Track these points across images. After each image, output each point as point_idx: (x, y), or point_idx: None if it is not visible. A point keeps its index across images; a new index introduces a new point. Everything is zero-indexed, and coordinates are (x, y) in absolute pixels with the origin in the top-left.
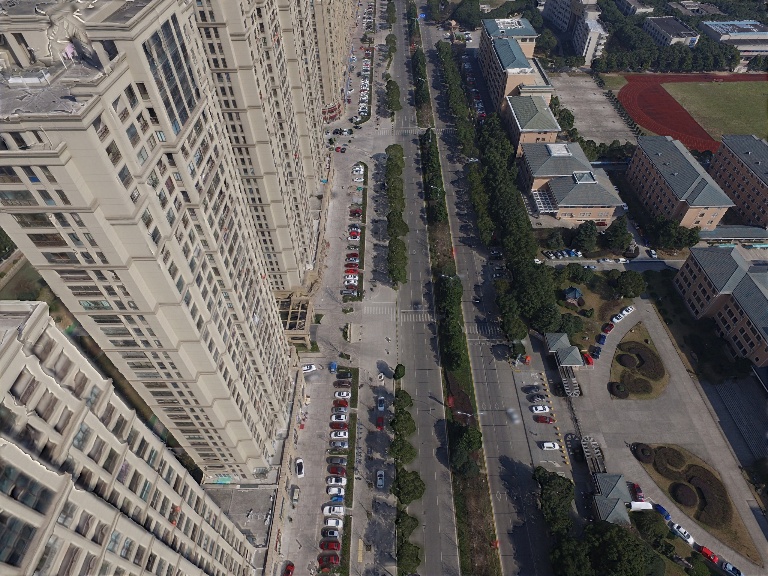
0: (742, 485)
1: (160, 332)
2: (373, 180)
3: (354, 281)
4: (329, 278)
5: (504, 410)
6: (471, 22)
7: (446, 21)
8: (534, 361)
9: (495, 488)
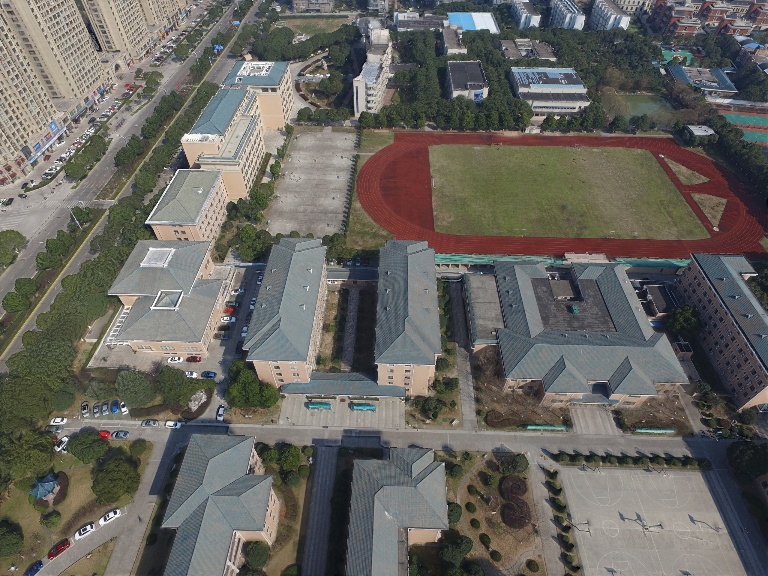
0: None
1: None
2: None
3: None
4: None
5: None
6: (265, 58)
7: (245, 54)
8: None
9: None
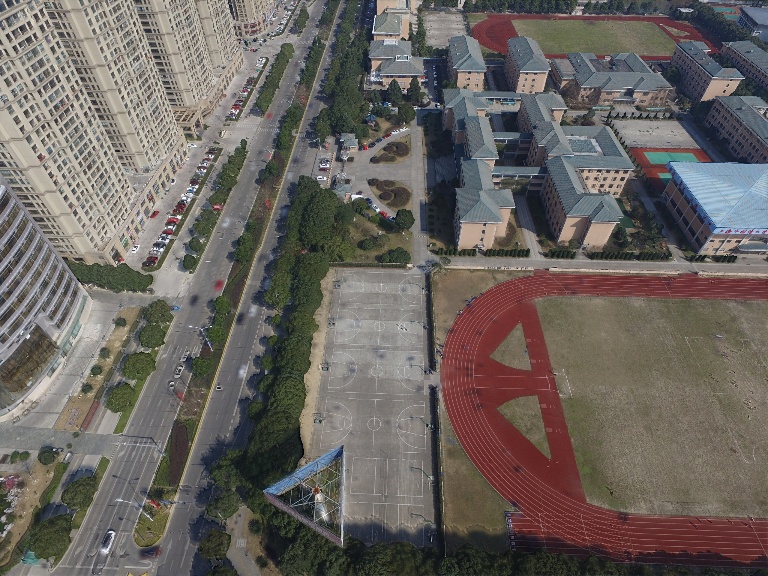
0: (422, 194)
1: (74, 26)
2: (270, 67)
3: (235, 111)
4: (220, 111)
5: (303, 166)
6: None
7: None
8: (332, 148)
9: (282, 193)
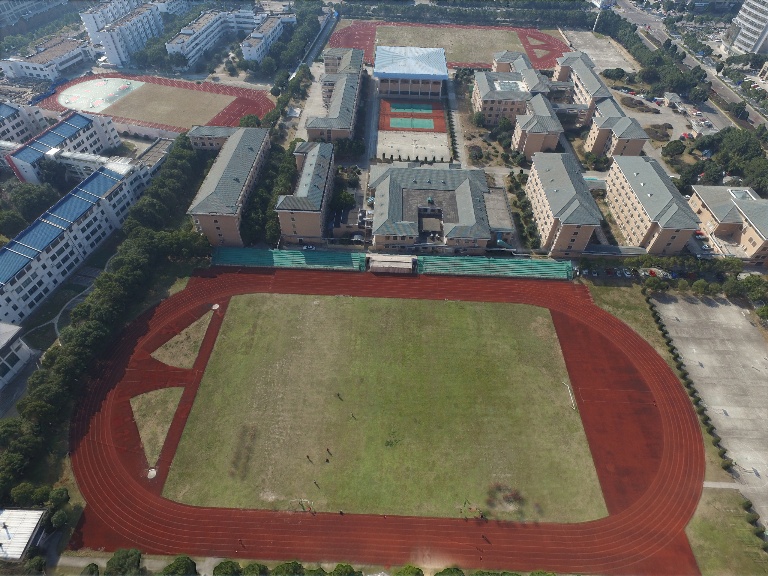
0: None
1: None
2: None
3: None
4: None
5: (723, 125)
6: None
7: None
8: None
9: (716, 108)
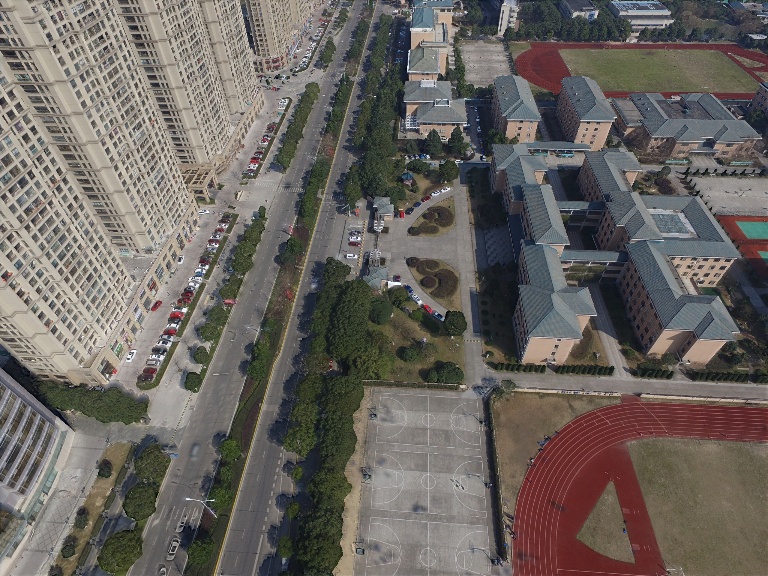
0: (471, 280)
1: (58, 100)
2: (293, 109)
3: (253, 167)
4: (237, 165)
5: (330, 239)
6: None
7: (398, 0)
8: (364, 215)
9: (306, 275)
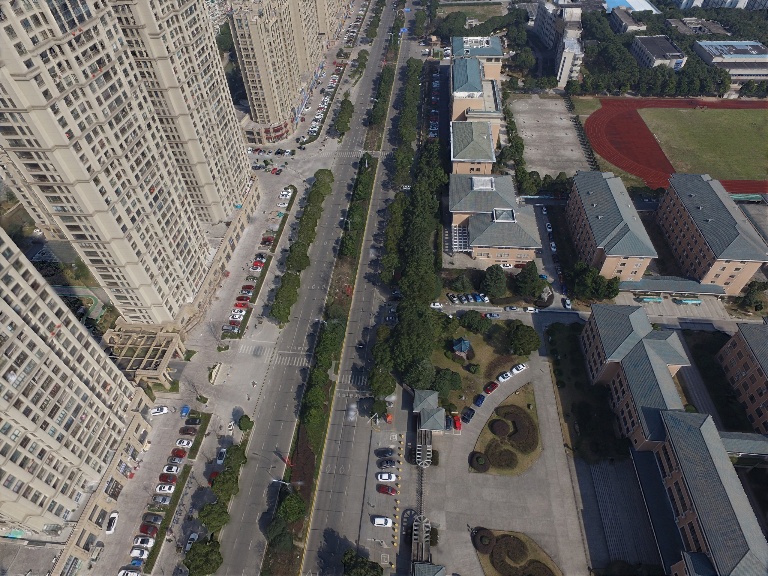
0: None
1: None
2: (298, 205)
3: (239, 316)
4: (216, 311)
5: (348, 475)
6: None
7: (428, 36)
8: (398, 420)
9: (308, 566)
